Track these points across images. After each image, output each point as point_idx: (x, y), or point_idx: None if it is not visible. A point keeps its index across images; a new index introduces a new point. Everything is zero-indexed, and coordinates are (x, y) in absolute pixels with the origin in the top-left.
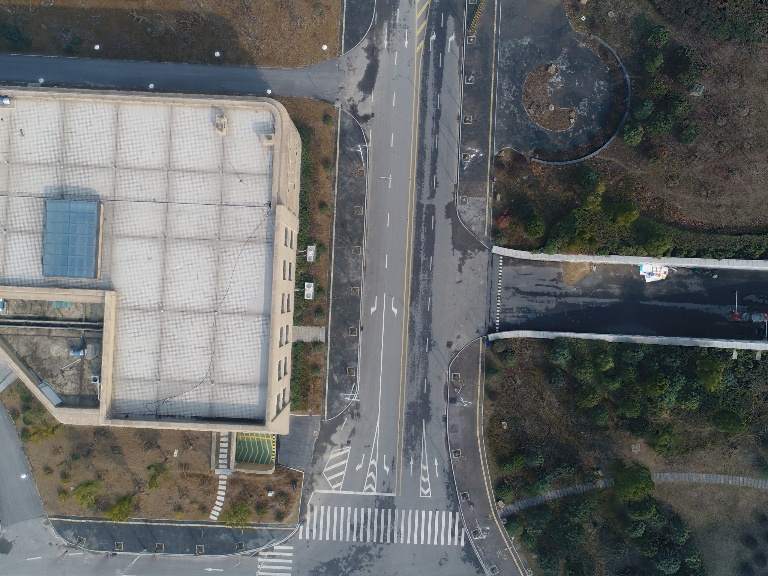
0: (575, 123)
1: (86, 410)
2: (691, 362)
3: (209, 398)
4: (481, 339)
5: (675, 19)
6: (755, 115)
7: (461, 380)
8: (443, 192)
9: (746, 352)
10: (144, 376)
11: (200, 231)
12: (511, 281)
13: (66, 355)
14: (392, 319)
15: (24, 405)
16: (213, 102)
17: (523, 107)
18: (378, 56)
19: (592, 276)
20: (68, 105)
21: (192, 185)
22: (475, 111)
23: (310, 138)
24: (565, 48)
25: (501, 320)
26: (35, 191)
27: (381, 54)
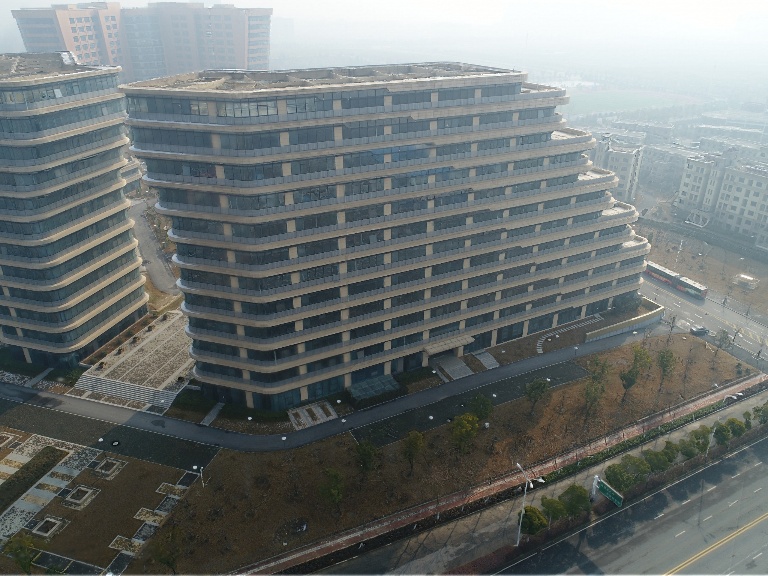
0: None
1: None
2: None
3: None
4: None
5: None
6: None
7: None
8: None
9: None
10: None
11: None
12: None
13: None
14: None
15: (149, 195)
16: None
17: None
18: None
19: None
20: None
21: None
22: None
23: None
24: None
25: None
26: None
27: None
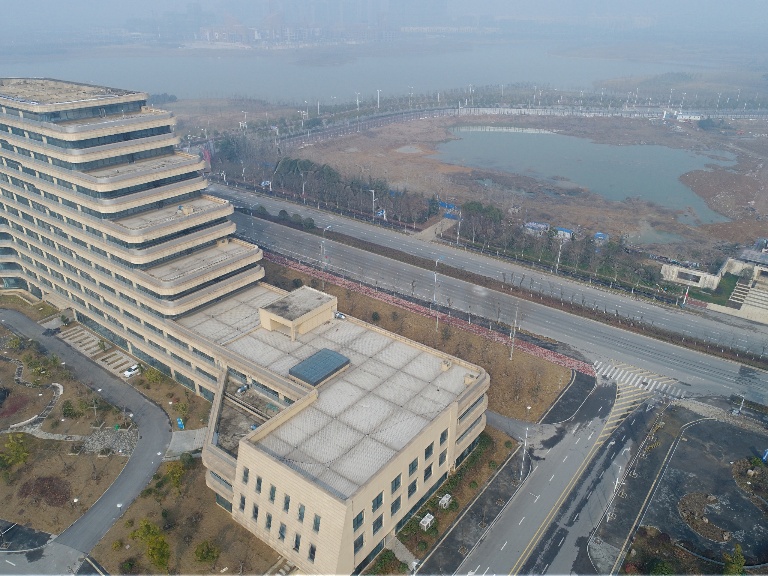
0: (728, 541)
1: (227, 454)
2: None
3: (318, 475)
4: None
5: None
6: None
7: None
8: (580, 527)
9: None
10: (289, 442)
11: (393, 399)
12: None
13: (246, 429)
14: None
15: None
16: (449, 356)
17: (678, 510)
18: (565, 435)
19: None
20: (370, 331)
21: (407, 380)
22: (631, 493)
23: (490, 444)
24: (728, 493)
25: None
26: (320, 348)
27: (568, 435)
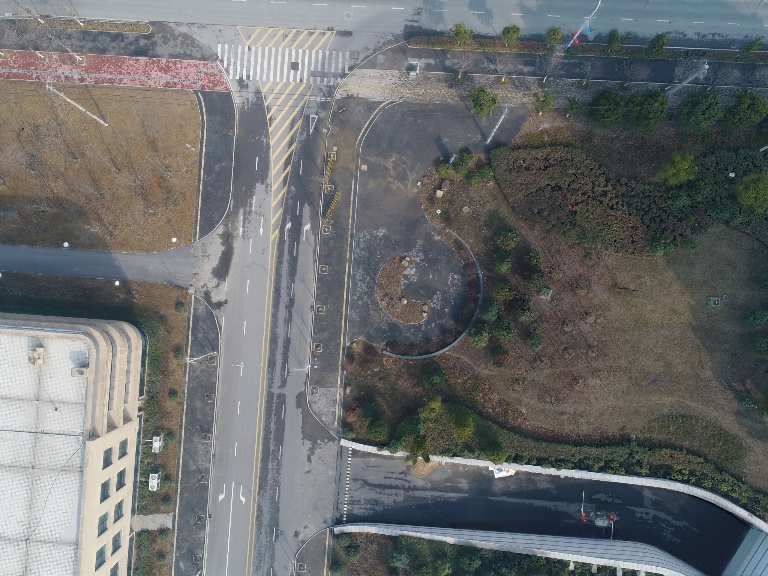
0: (428, 316)
1: None
2: (530, 569)
3: None
4: (328, 530)
5: (527, 220)
6: (601, 323)
7: (307, 571)
8: (294, 381)
9: (583, 563)
10: None
11: (15, 458)
12: (360, 473)
13: None
14: (240, 507)
15: None
16: (28, 333)
17: (376, 298)
18: (233, 243)
19: (441, 470)
20: None
21: (8, 412)
22: (328, 301)
23: (160, 327)
24: (420, 240)
25: (349, 512)
26: None
27: (236, 241)
